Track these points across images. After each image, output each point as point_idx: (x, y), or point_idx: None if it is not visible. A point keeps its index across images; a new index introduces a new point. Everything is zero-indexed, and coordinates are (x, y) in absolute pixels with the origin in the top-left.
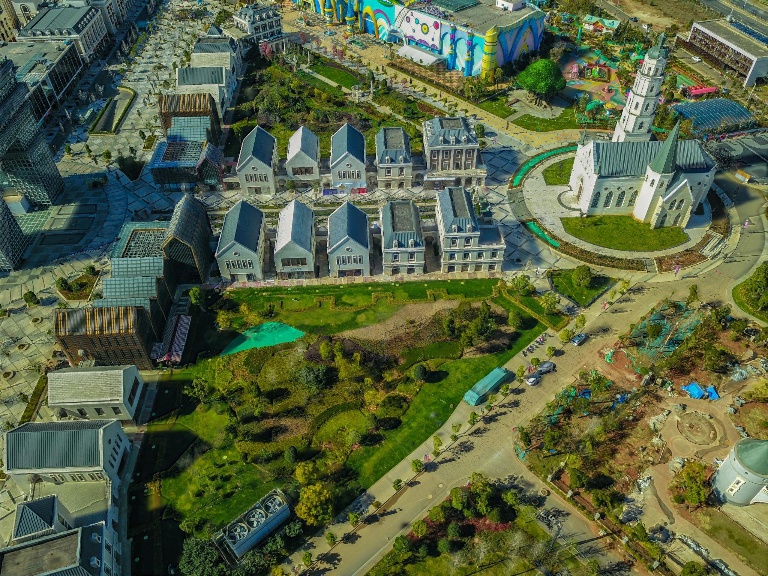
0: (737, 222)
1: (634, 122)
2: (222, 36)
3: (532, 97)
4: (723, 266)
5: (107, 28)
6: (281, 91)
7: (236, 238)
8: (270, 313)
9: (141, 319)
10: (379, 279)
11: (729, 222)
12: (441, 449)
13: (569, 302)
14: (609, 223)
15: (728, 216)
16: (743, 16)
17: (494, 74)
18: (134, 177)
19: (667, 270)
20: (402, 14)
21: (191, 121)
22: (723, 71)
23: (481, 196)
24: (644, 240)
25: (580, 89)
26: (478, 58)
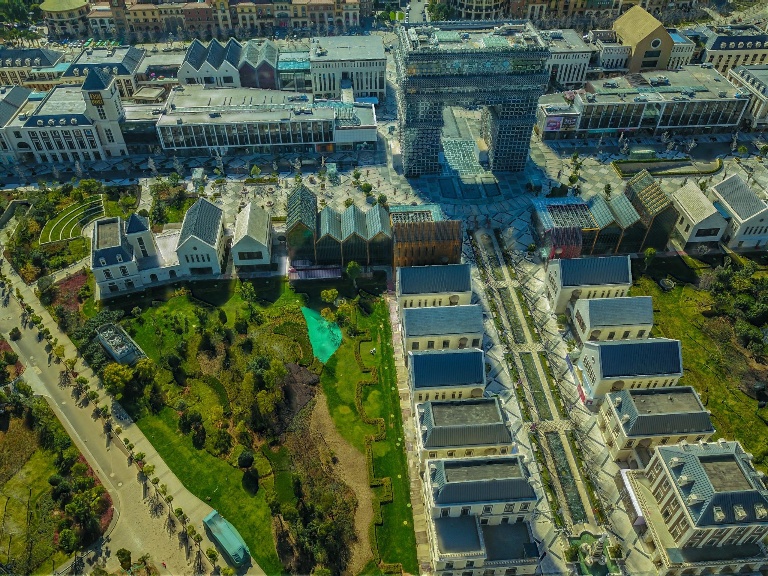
0: None
1: None
2: None
3: None
4: None
5: None
6: None
7: (406, 269)
8: (355, 334)
9: (303, 234)
10: (408, 424)
11: None
12: (159, 486)
13: None
14: None
15: None
16: None
17: None
18: None
19: None
20: None
21: (627, 208)
22: None
23: (626, 568)
24: None
25: None
26: None
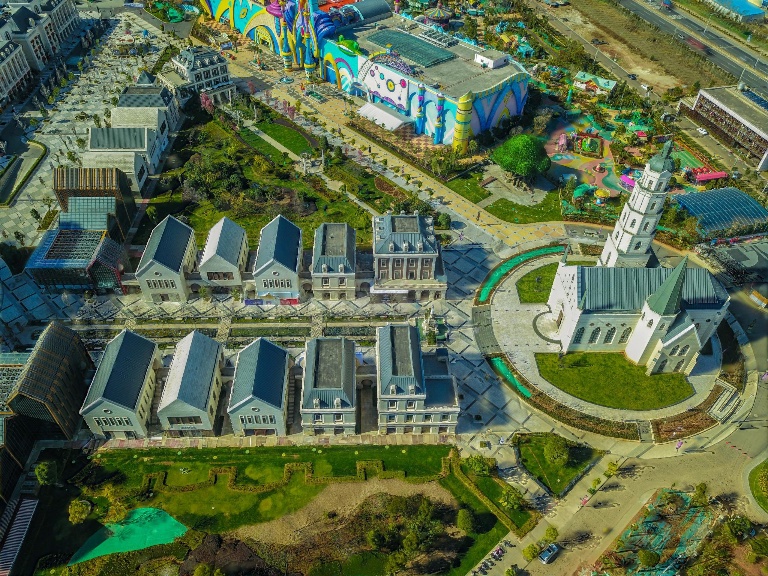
0: (753, 366)
1: (629, 242)
2: (155, 84)
3: (510, 176)
4: (737, 435)
5: (32, 64)
6: (217, 156)
7: (106, 392)
8: (148, 492)
9: None
10: (297, 441)
11: (743, 366)
12: None
13: (539, 488)
14: (595, 364)
15: (743, 362)
16: (754, 77)
17: (468, 144)
18: (17, 270)
19: (666, 440)
20: (366, 66)
21: (92, 202)
22: (733, 149)
23: (439, 314)
24: (638, 392)
25: (567, 166)
26: (450, 125)
